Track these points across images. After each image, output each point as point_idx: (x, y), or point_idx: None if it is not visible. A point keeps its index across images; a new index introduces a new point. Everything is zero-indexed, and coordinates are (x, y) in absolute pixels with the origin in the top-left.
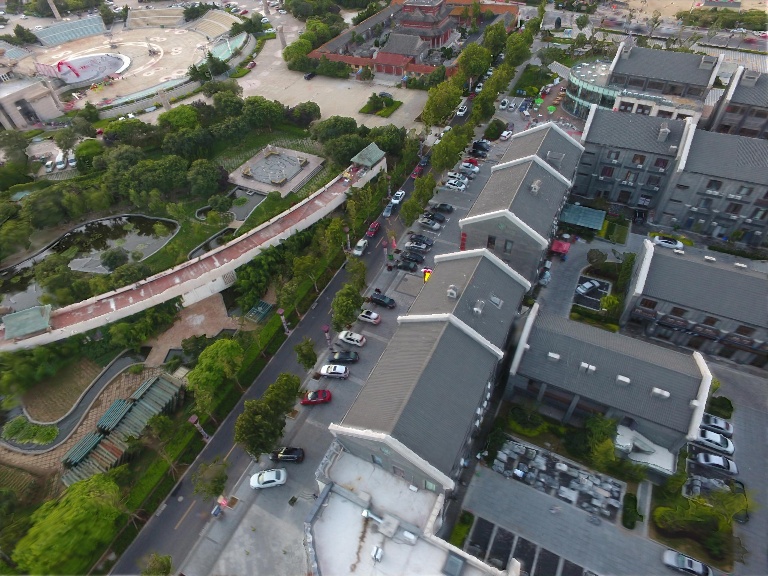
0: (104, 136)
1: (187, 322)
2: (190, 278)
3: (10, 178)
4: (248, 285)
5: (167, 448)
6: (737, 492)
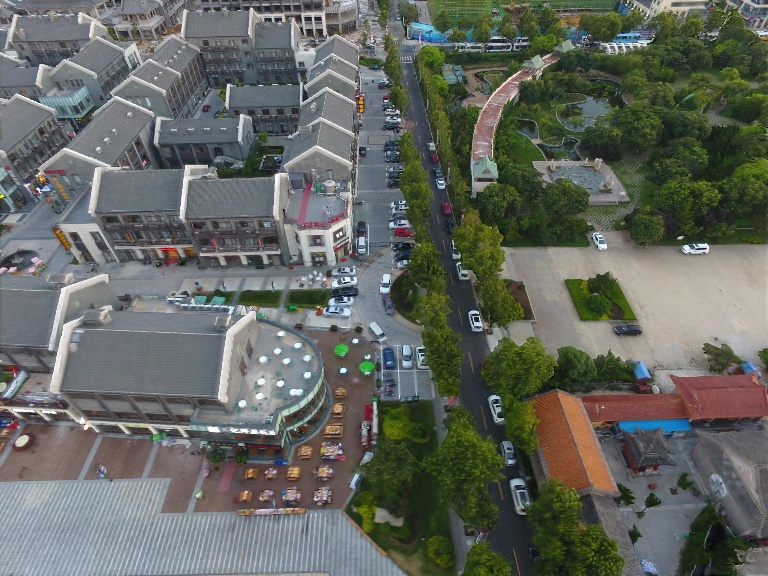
0: (767, 139)
1: (483, 103)
2: (498, 97)
3: (744, 106)
4: (467, 107)
5: (429, 75)
6: (218, 113)
